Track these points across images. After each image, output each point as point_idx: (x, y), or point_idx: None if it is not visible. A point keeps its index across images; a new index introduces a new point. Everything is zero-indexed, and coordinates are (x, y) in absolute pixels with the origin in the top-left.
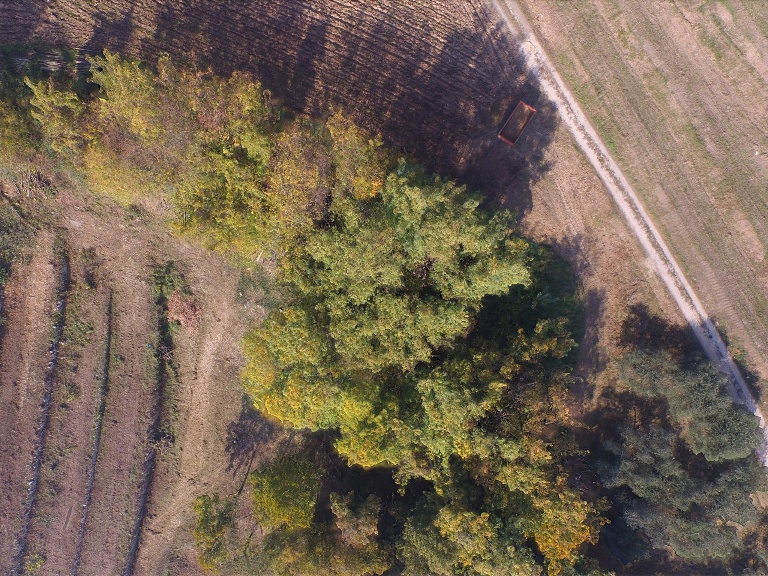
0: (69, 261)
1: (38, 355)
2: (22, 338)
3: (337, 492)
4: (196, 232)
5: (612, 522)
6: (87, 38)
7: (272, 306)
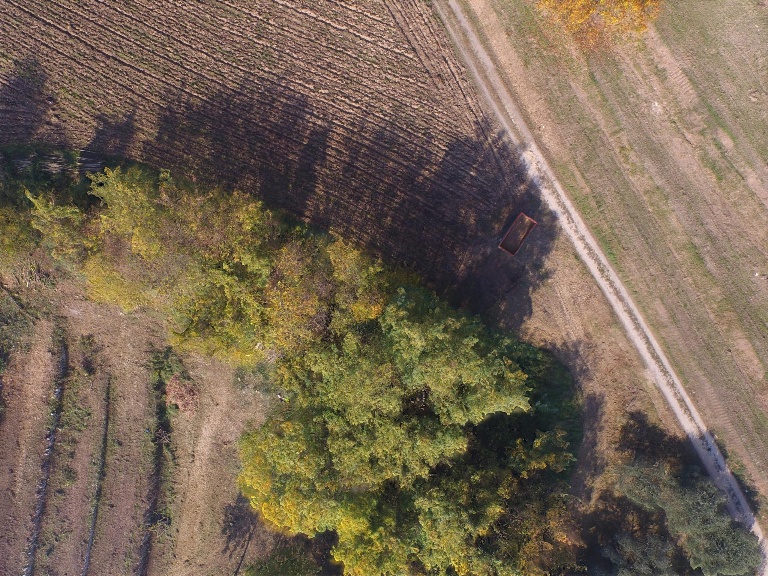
0: (68, 348)
1: (35, 442)
2: (19, 425)
3: None
4: None
5: None
6: (89, 139)
7: (270, 392)
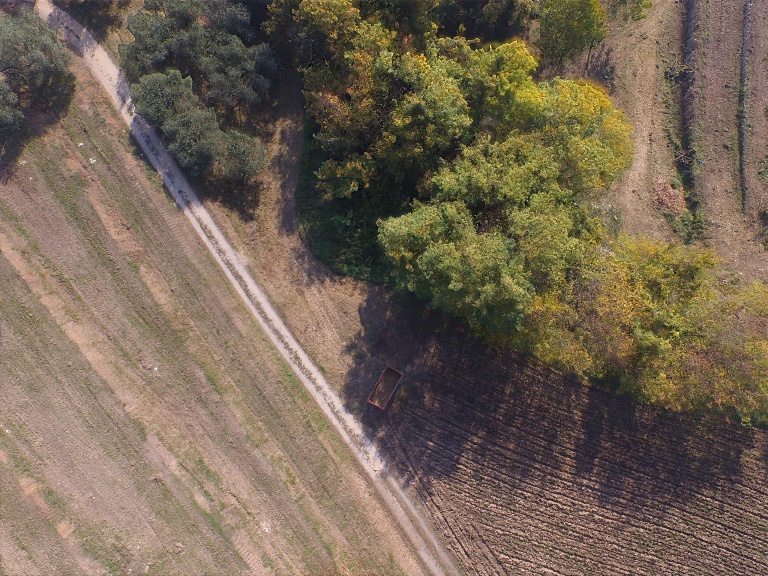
0: None
1: None
2: None
3: None
4: None
5: (256, 12)
6: None
7: None
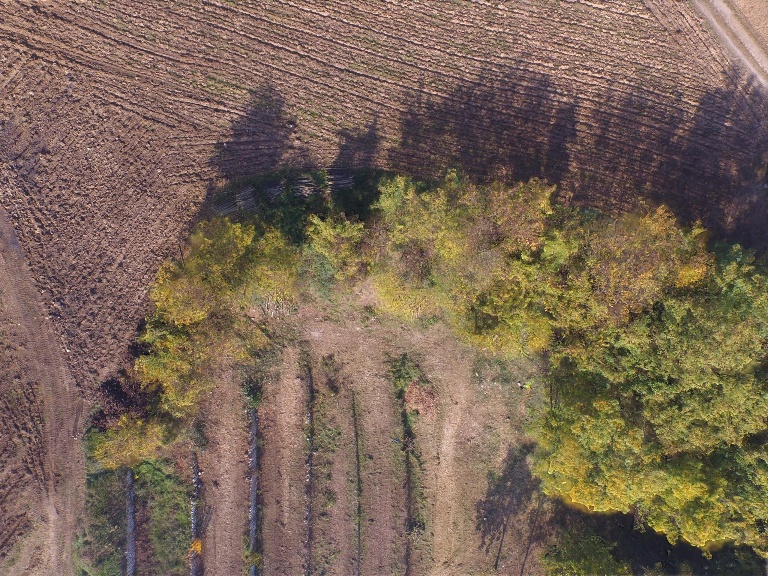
0: (311, 371)
1: (296, 469)
2: (278, 456)
3: (630, 562)
4: (429, 322)
5: None
6: (333, 157)
7: (509, 381)
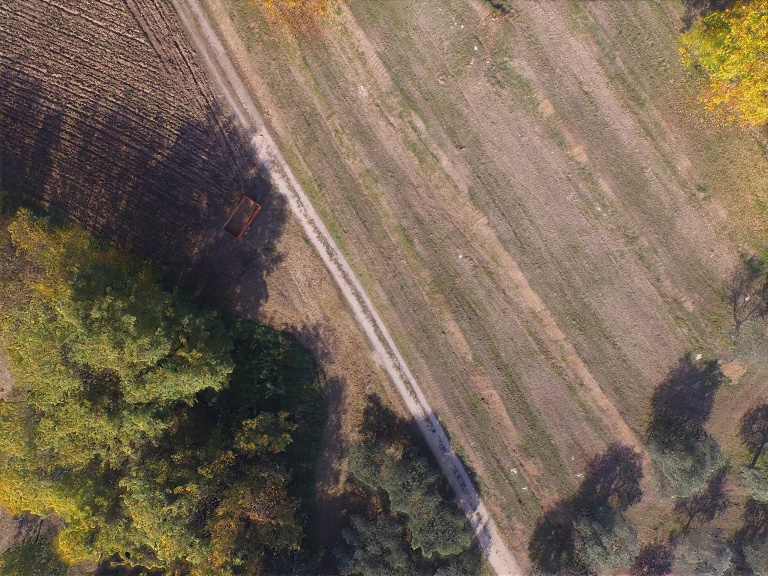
0: None
1: None
2: None
3: (91, 572)
4: None
5: None
6: None
7: None
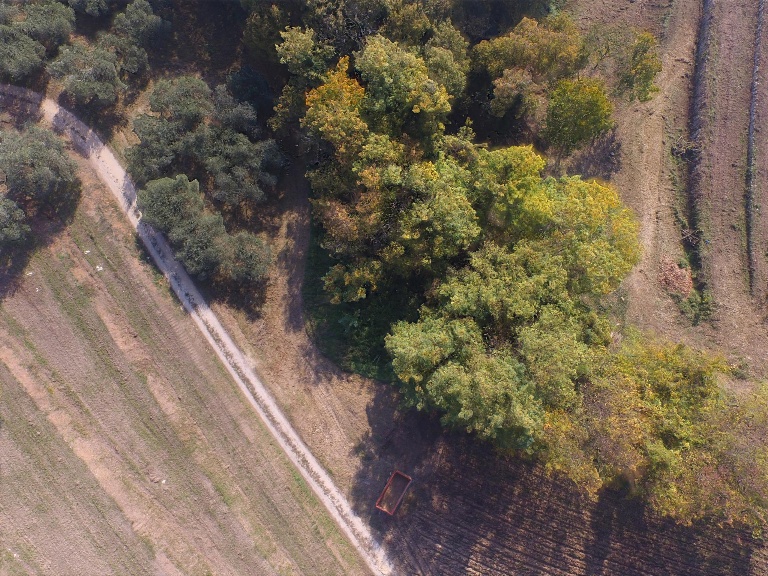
0: None
1: None
2: None
3: None
4: None
5: (262, 106)
6: None
7: None
